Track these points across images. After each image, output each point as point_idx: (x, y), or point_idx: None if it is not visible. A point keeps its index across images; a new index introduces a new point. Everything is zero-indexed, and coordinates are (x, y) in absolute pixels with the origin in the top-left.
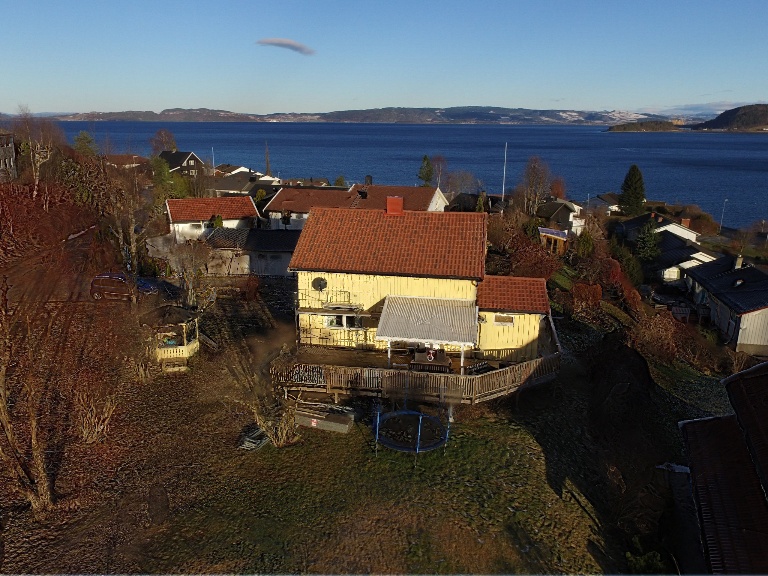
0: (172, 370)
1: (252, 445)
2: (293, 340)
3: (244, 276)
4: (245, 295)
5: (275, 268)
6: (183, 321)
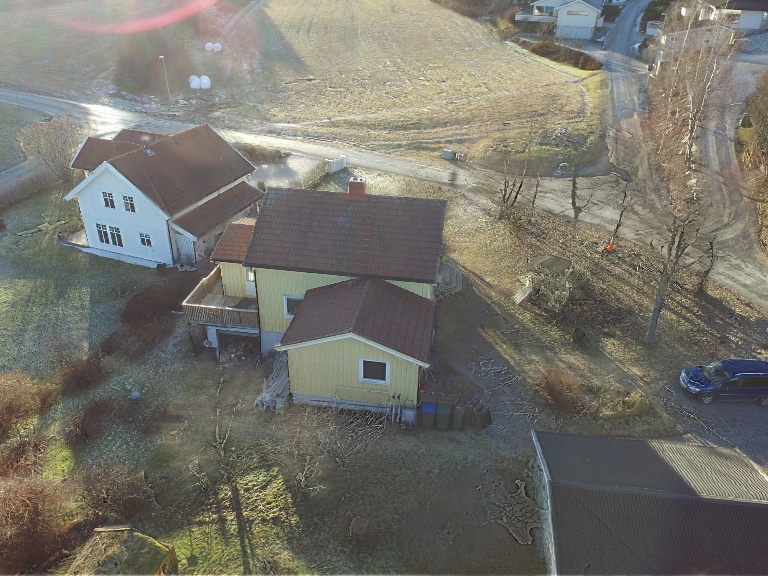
0: None
1: None
2: (453, 309)
3: None
4: None
5: None
6: None
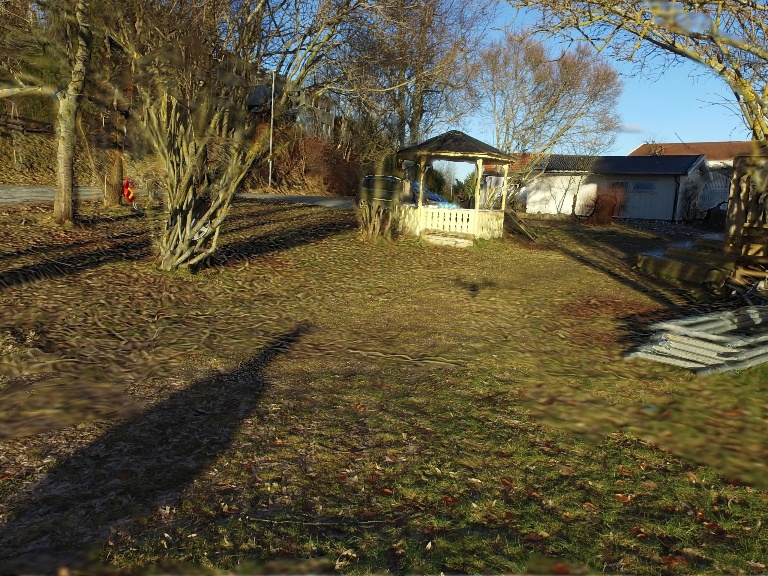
0: (439, 242)
1: (703, 349)
2: None
3: (583, 218)
4: (590, 216)
5: (639, 206)
6: (479, 150)
